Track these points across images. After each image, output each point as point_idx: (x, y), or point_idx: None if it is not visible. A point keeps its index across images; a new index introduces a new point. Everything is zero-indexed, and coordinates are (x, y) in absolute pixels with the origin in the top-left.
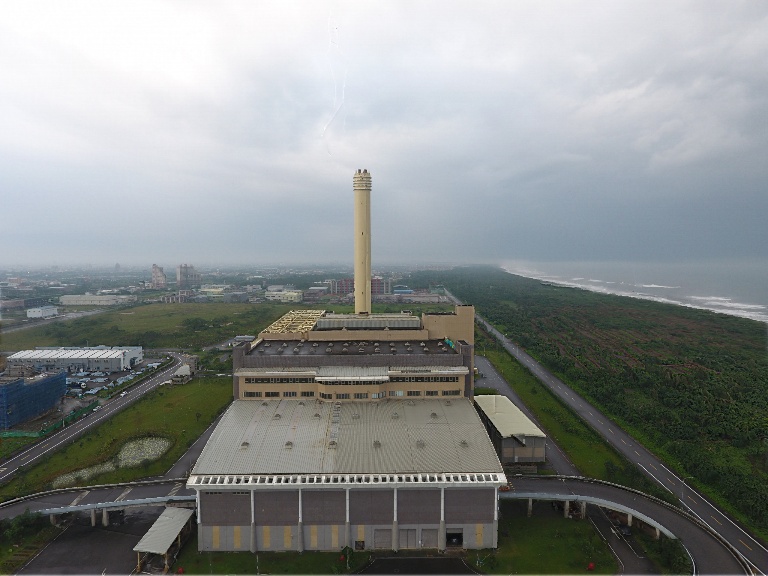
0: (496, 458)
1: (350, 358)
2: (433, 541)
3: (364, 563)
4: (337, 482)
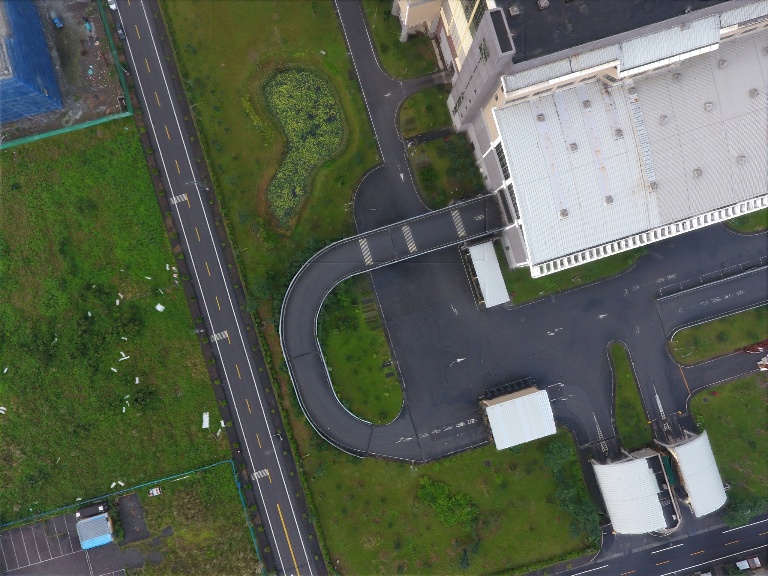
0: None
1: (673, 21)
2: None
3: (645, 245)
4: (665, 235)
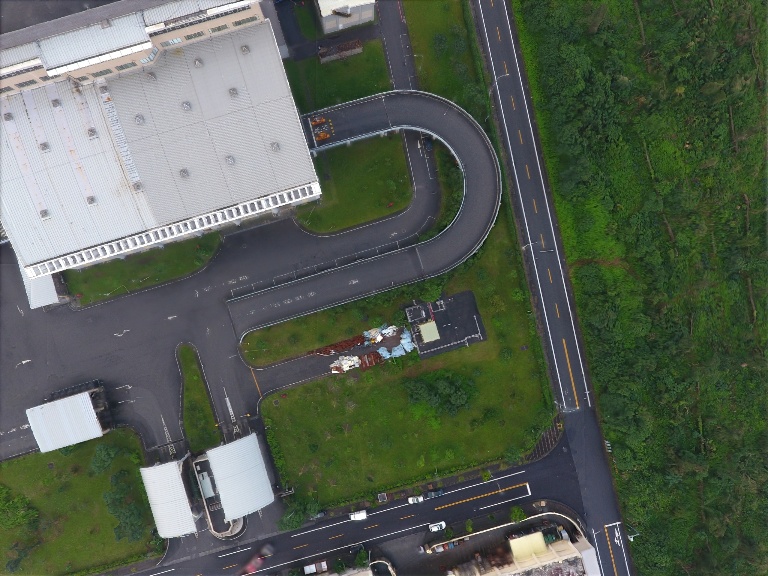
0: (310, 162)
1: (74, 19)
2: (267, 210)
3: (217, 246)
4: (166, 236)
